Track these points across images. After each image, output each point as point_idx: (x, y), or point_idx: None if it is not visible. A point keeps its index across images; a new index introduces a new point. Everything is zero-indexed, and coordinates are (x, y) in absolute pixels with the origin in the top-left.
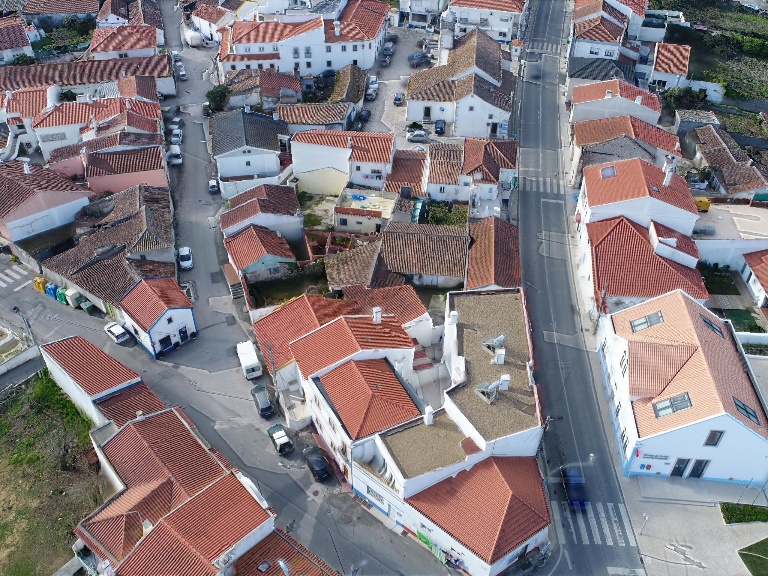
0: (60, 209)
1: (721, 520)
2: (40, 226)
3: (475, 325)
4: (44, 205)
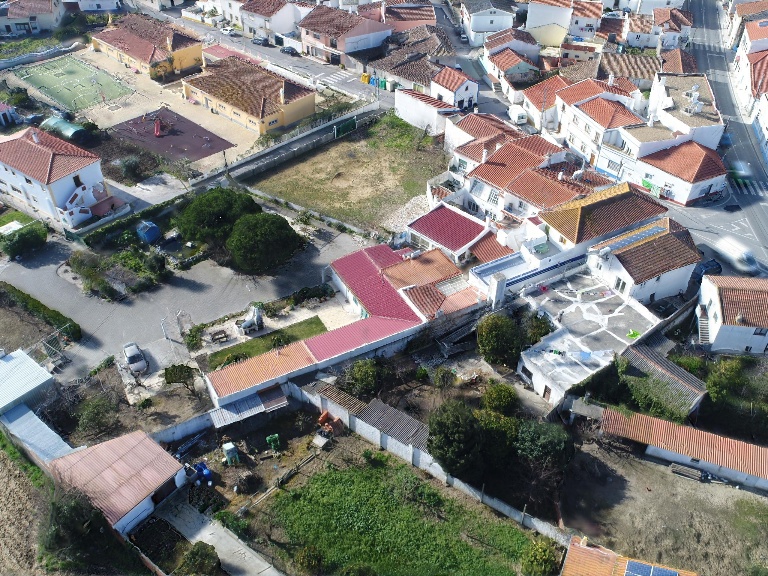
0: (375, 35)
1: None
2: (362, 45)
3: (676, 87)
4: (368, 30)
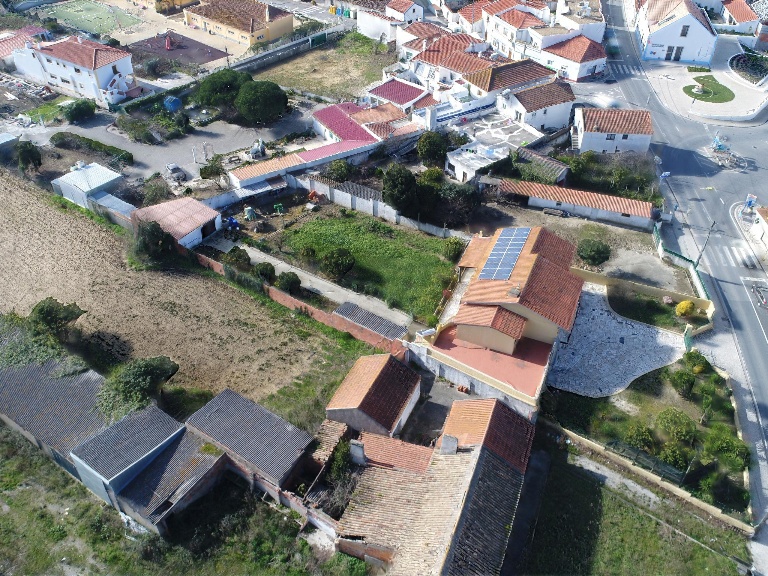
0: None
1: (686, 71)
2: None
3: (574, 1)
4: None
